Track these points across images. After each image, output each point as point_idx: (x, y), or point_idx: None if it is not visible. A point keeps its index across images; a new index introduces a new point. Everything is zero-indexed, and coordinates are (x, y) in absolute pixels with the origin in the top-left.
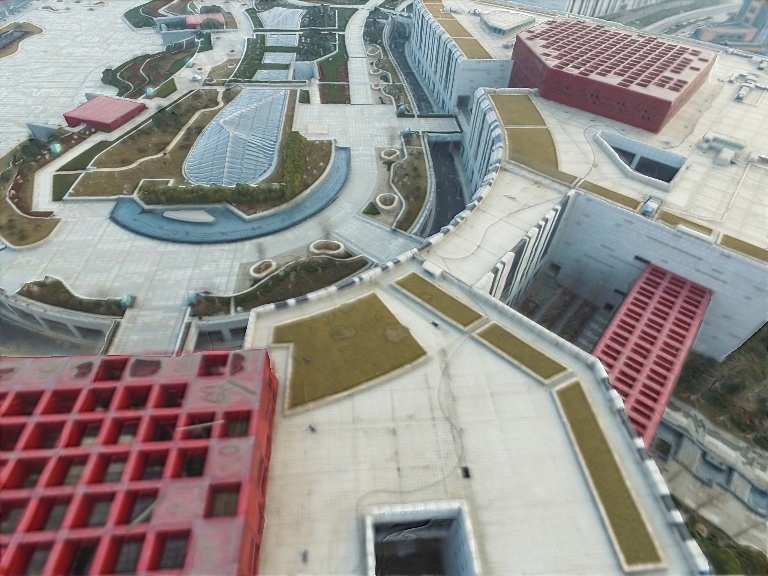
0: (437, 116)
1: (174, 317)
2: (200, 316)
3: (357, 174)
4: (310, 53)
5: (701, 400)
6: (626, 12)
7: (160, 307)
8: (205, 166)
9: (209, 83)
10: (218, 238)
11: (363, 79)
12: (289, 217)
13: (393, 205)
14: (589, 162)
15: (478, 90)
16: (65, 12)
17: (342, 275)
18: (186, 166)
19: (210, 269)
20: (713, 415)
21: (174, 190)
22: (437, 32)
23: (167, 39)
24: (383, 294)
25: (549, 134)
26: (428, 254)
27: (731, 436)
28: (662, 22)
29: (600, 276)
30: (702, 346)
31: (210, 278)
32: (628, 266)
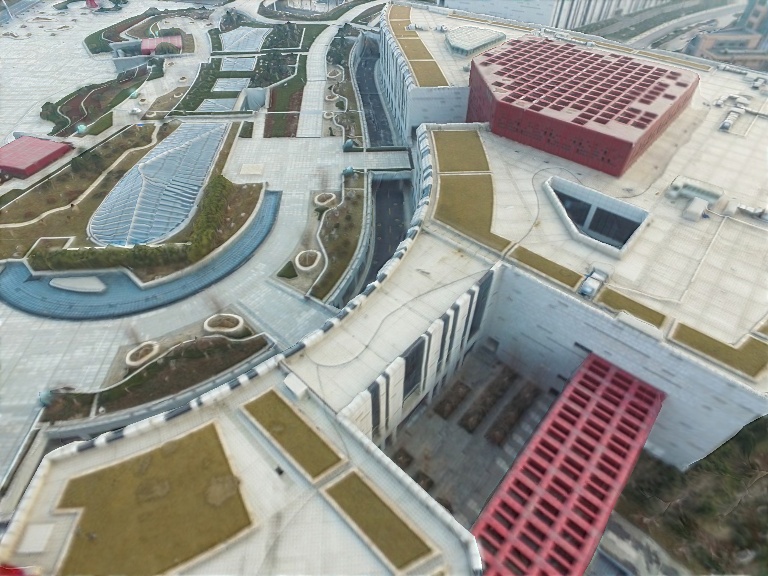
0: (388, 149)
1: (22, 422)
2: (52, 421)
3: (282, 225)
4: (264, 78)
5: (656, 523)
6: (621, 18)
7: (10, 408)
8: (112, 220)
9: (148, 116)
10: (104, 312)
11: (316, 107)
12: (192, 283)
13: (313, 265)
14: (530, 219)
15: (420, 126)
16: (26, 38)
17: (233, 361)
18: (92, 220)
19: (83, 355)
20: (670, 544)
21: (62, 255)
22: (394, 54)
23: (120, 66)
24: (227, 423)
25: (490, 182)
26: (300, 359)
27: (691, 574)
28: (660, 27)
29: (541, 358)
30: (660, 451)
31: (79, 367)
32: (569, 352)
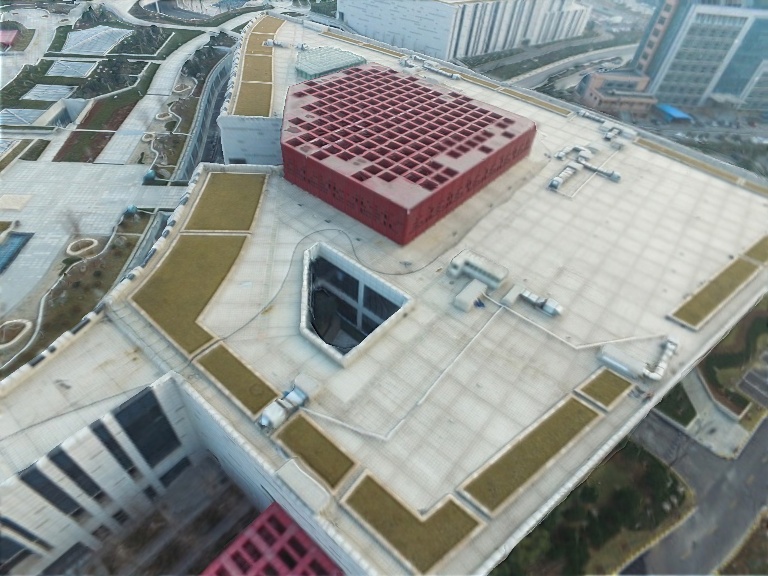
0: None
1: None
2: None
3: (6, 281)
4: (90, 88)
5: None
6: (528, 48)
7: None
8: None
9: None
10: None
11: (140, 126)
12: None
13: (9, 343)
14: (262, 302)
15: None
16: None
17: None
18: None
19: None
20: None
21: None
22: None
23: None
24: None
25: (239, 247)
26: None
27: None
28: (565, 61)
29: None
30: None
31: None
32: (262, 492)
